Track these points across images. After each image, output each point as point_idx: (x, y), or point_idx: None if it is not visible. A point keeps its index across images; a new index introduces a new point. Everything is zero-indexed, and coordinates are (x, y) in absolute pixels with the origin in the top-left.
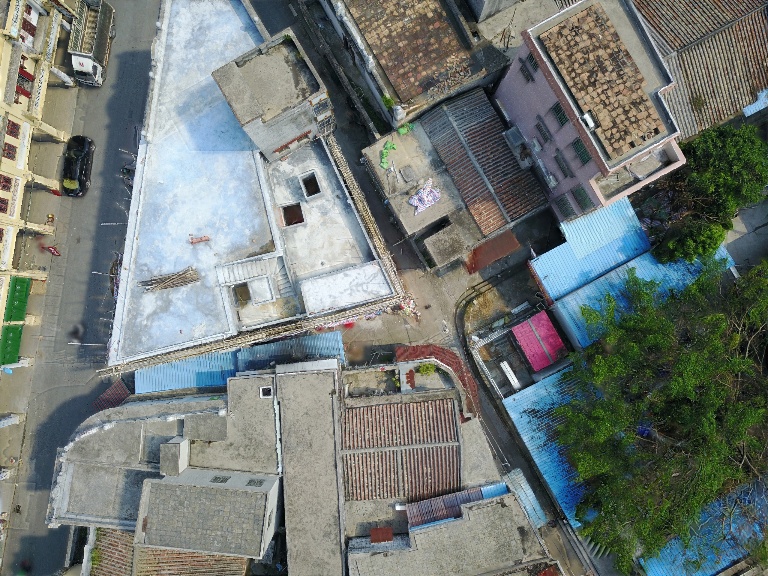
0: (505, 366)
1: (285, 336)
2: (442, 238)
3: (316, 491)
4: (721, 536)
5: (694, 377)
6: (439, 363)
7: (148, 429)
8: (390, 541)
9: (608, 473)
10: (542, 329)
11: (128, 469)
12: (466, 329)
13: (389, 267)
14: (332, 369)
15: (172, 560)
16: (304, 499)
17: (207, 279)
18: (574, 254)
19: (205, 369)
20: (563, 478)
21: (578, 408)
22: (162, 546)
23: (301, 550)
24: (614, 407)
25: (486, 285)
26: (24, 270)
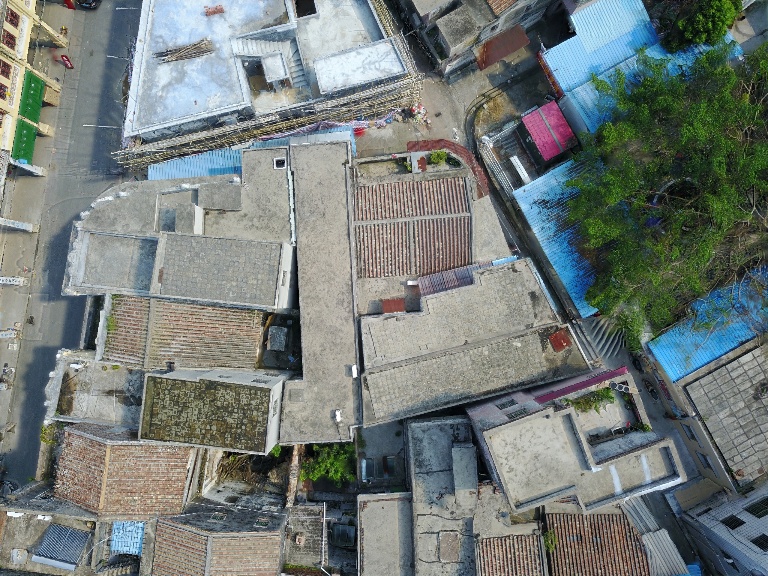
0: (515, 160)
1: (297, 132)
2: (454, 19)
3: (329, 260)
4: (730, 306)
5: (704, 129)
6: (450, 151)
7: (163, 202)
8: (402, 311)
9: (618, 239)
10: (552, 119)
11: (143, 241)
12: (476, 133)
13: (401, 48)
14: (345, 140)
15: (187, 328)
16: (317, 267)
17: (222, 51)
18: (584, 47)
19: (218, 165)
20: (573, 268)
21: (588, 181)
22: (178, 296)
23: (314, 318)
24: (624, 173)
25: (496, 91)
26: (38, 70)
